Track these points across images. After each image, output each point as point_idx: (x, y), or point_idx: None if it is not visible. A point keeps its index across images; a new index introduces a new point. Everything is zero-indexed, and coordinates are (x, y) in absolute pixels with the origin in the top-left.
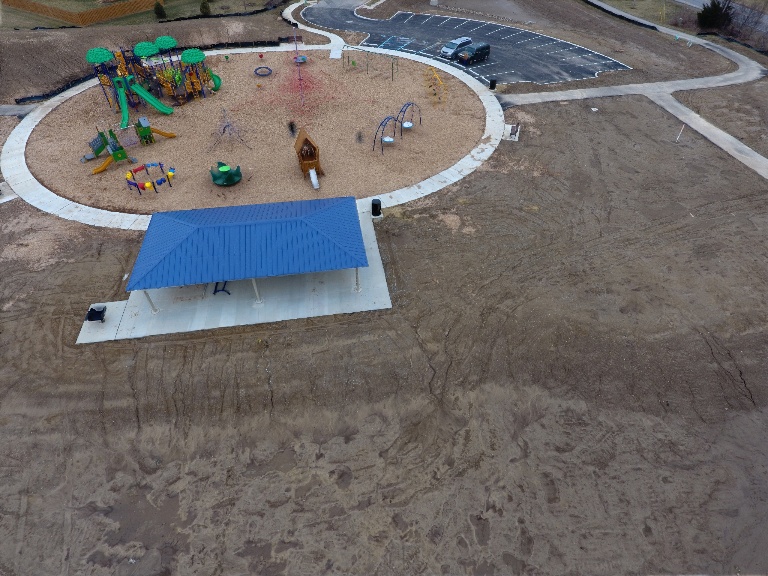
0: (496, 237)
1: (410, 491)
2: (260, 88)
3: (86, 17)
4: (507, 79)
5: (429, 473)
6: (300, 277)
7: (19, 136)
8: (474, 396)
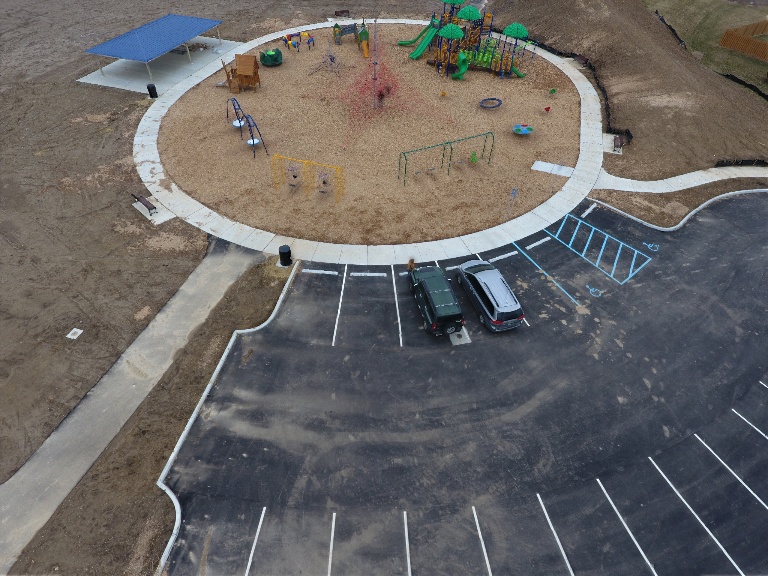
0: (51, 125)
1: (6, 70)
2: (443, 97)
3: (732, 39)
4: (304, 302)
5: (3, 74)
6: (141, 66)
7: (417, 22)
8: (2, 90)
